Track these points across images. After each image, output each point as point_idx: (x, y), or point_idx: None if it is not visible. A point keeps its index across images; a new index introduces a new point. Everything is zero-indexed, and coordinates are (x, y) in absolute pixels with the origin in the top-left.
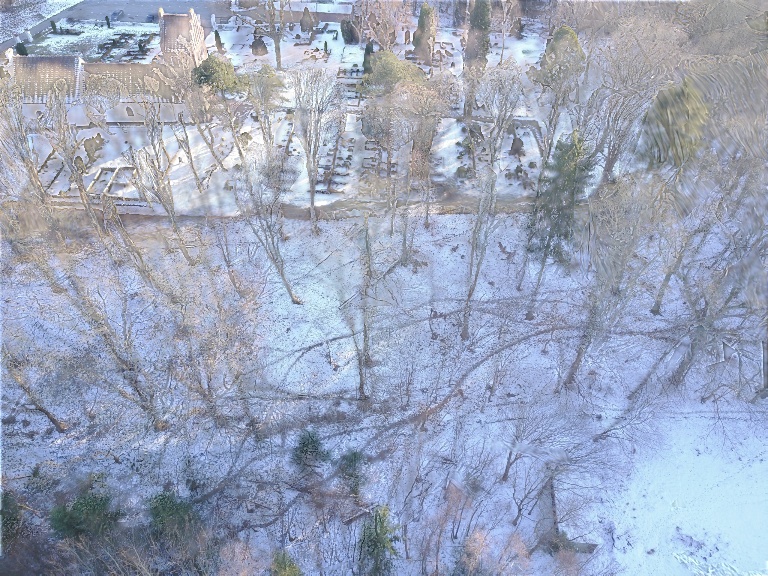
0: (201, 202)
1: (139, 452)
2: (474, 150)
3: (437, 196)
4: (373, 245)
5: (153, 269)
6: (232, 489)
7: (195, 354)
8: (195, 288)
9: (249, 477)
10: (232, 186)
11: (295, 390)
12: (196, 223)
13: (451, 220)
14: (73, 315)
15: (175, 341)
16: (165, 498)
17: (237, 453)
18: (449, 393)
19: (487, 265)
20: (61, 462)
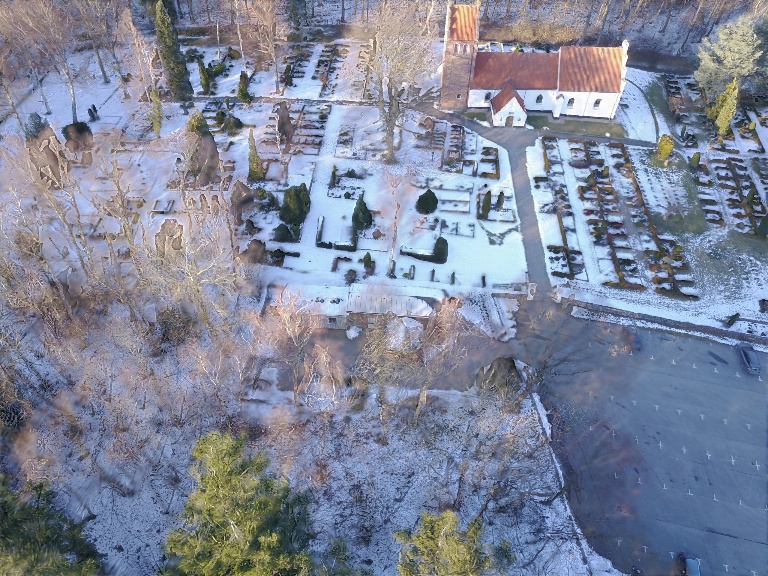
0: None
1: None
2: None
3: None
4: None
5: None
6: None
7: None
8: None
9: None
10: None
11: (353, 3)
12: None
13: None
14: None
15: None
16: None
17: None
18: (286, 1)
19: None
20: None
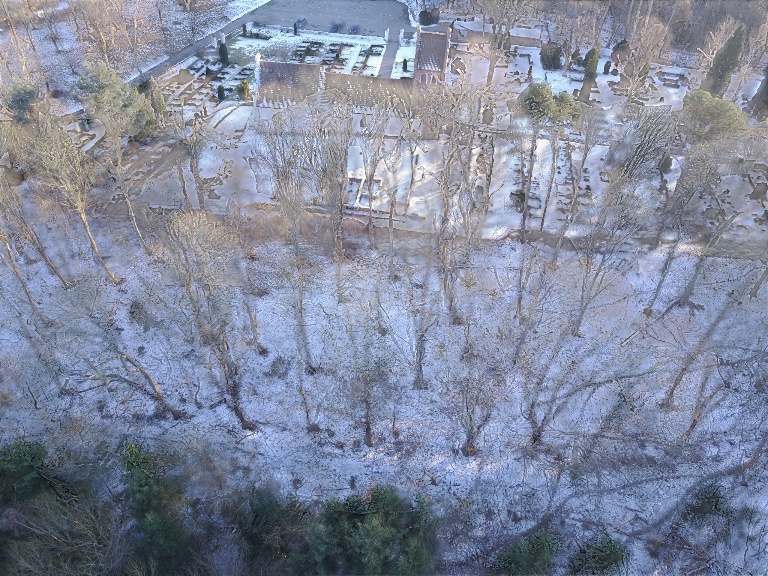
0: None
1: (455, 476)
2: (714, 191)
3: (691, 236)
4: (646, 283)
5: (430, 287)
6: (557, 525)
7: (484, 378)
8: (474, 310)
9: (571, 514)
10: None
11: (595, 427)
12: (458, 243)
13: (721, 264)
14: (360, 327)
15: (463, 363)
16: (490, 527)
17: (553, 488)
18: (758, 447)
19: (766, 314)
20: (377, 477)
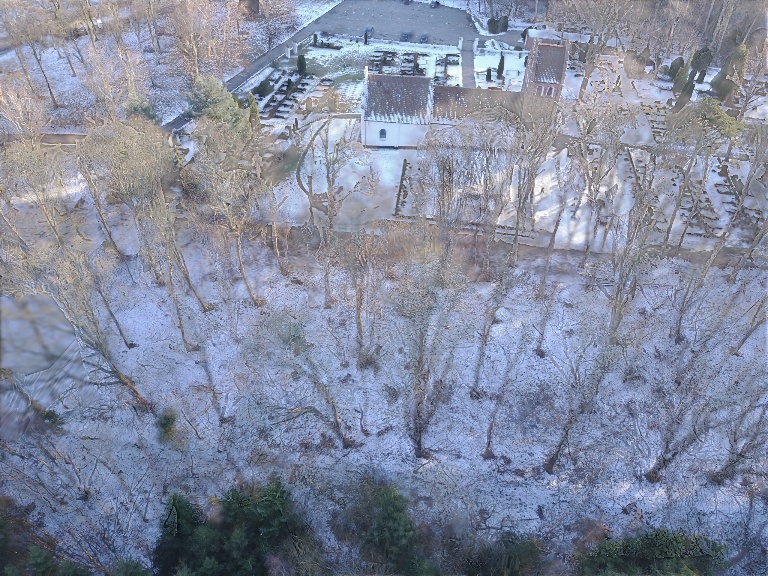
0: (583, 237)
1: (645, 504)
2: None
3: None
4: None
5: (579, 306)
6: (759, 554)
7: (649, 400)
8: (628, 330)
9: None
10: (606, 222)
11: None
12: (596, 260)
13: None
14: (518, 348)
15: (627, 385)
16: None
17: (747, 515)
18: None
19: None
20: (565, 506)
